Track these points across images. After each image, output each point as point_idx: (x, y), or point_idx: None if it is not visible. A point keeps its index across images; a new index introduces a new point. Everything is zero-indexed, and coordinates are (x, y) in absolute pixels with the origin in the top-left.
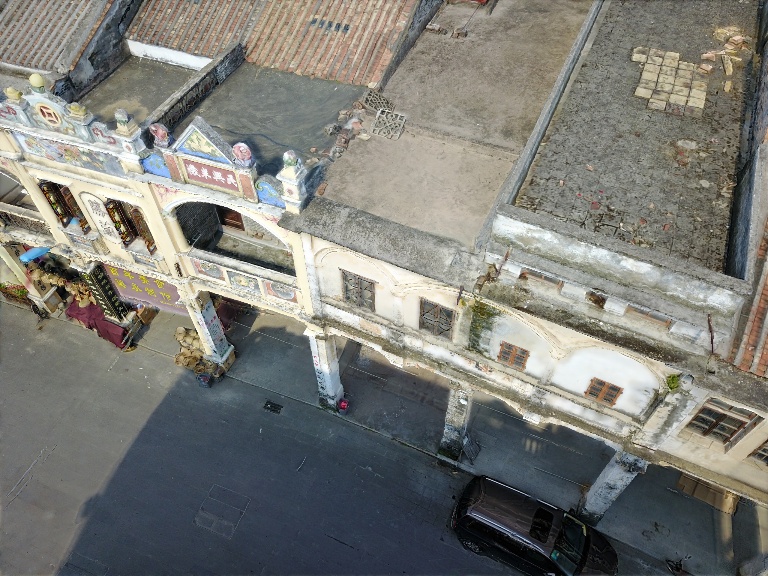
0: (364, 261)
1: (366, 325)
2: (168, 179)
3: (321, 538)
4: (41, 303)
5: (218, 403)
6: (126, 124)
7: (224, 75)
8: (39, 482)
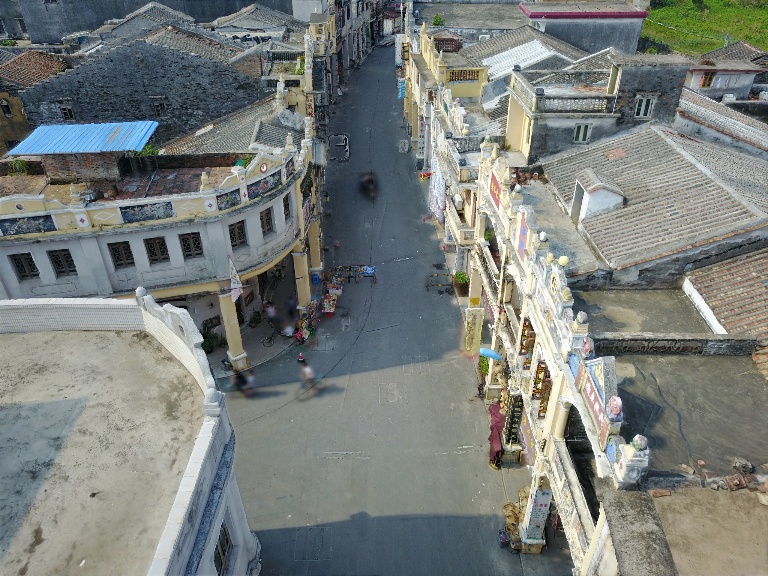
0: None
1: None
2: (574, 380)
3: None
4: (487, 387)
5: (492, 563)
6: (579, 324)
7: (713, 351)
8: (367, 474)
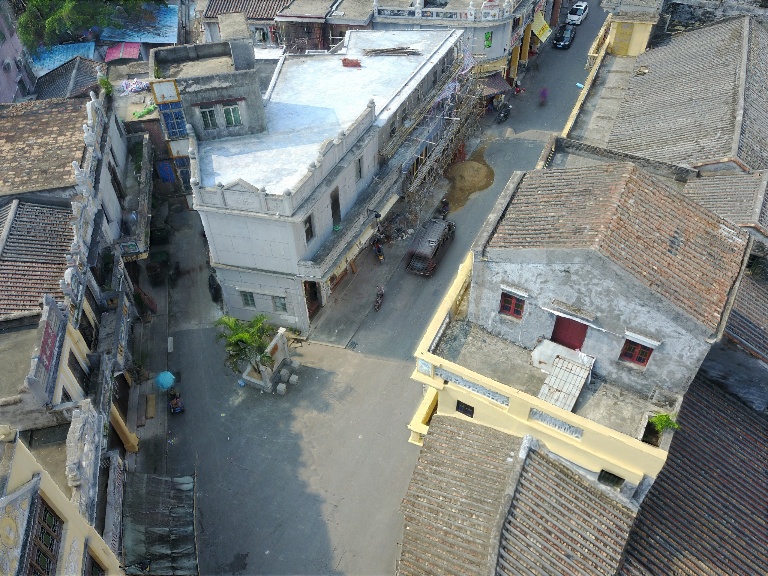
0: None
1: None
2: None
3: None
4: None
5: None
6: None
7: None
8: None
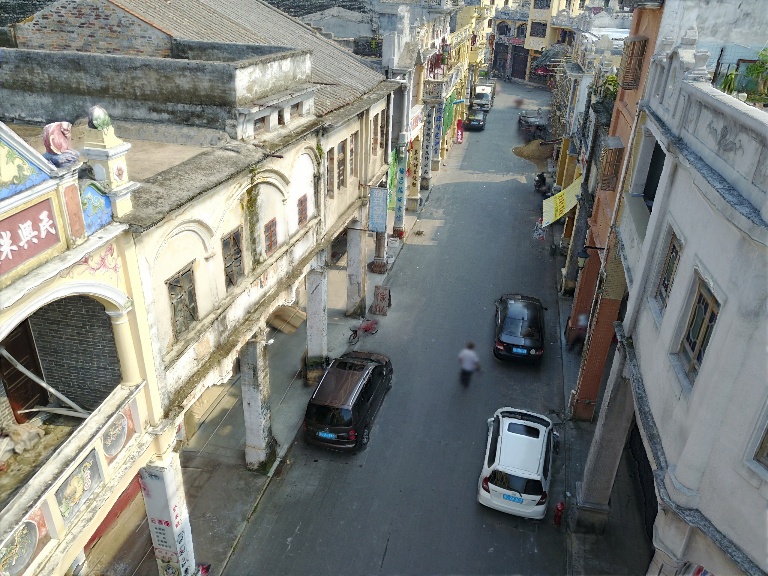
0: (183, 235)
1: (200, 350)
2: None
3: (386, 574)
4: None
5: None
6: None
7: None
8: None
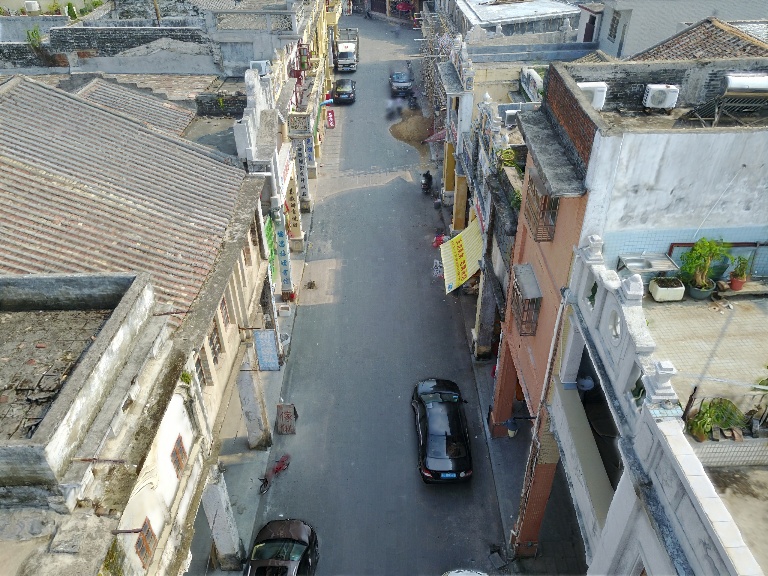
0: None
1: None
2: None
3: None
4: None
5: None
6: None
7: None
8: None
